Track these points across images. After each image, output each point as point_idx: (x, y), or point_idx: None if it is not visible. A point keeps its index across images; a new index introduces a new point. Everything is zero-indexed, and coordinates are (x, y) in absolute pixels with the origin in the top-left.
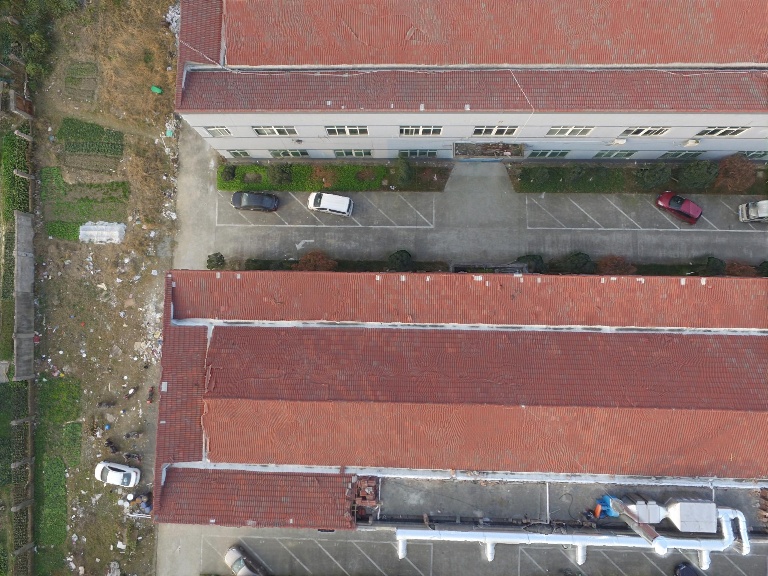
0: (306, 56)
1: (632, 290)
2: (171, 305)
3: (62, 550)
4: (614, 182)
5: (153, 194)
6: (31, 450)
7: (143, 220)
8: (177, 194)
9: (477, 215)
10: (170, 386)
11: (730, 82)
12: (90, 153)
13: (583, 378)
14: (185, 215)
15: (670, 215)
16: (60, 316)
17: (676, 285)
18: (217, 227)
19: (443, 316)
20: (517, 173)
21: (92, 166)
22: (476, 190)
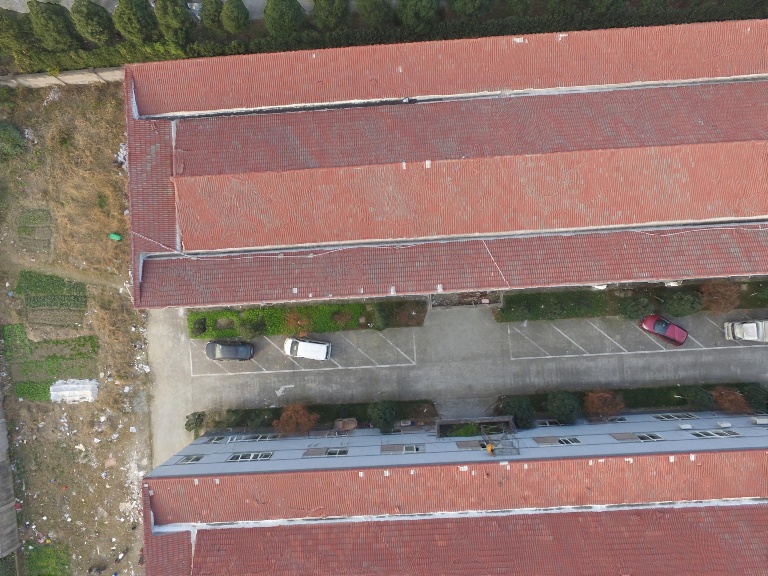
0: (267, 237)
1: (621, 470)
2: (151, 513)
3: None
4: (597, 305)
5: (123, 347)
6: None
7: (115, 377)
8: (148, 345)
9: (459, 348)
10: None
11: (710, 241)
12: (53, 307)
13: (576, 565)
14: (158, 367)
15: (655, 336)
16: (40, 481)
17: (665, 463)
18: (193, 378)
19: (431, 506)
20: None
21: (56, 321)
22: (456, 322)
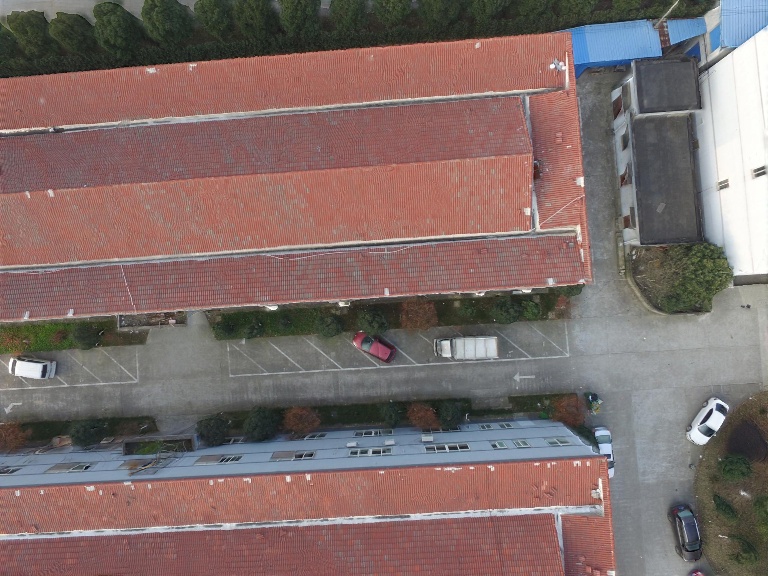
0: None
1: (241, 489)
2: None
3: None
4: (313, 323)
5: None
6: None
7: None
8: None
9: (180, 366)
10: None
11: (335, 264)
12: None
13: None
14: None
15: None
16: None
17: (282, 482)
18: None
19: (66, 524)
20: (216, 320)
21: None
22: (177, 340)
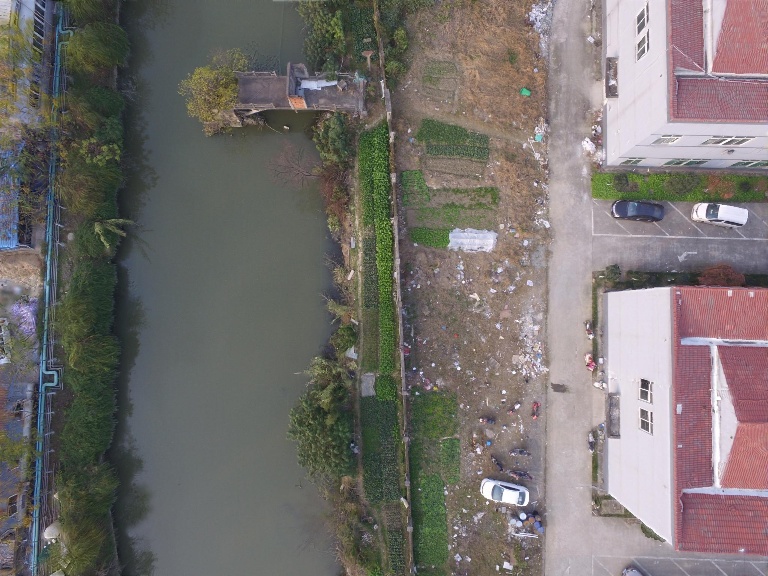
0: None
1: None
2: None
3: (444, 570)
4: None
5: (525, 201)
6: (408, 467)
7: (519, 228)
8: (549, 201)
9: None
10: (683, 409)
11: None
12: (453, 157)
13: None
14: (559, 224)
15: None
16: (431, 327)
17: None
18: (594, 237)
19: None
20: None
21: (457, 170)
22: None
